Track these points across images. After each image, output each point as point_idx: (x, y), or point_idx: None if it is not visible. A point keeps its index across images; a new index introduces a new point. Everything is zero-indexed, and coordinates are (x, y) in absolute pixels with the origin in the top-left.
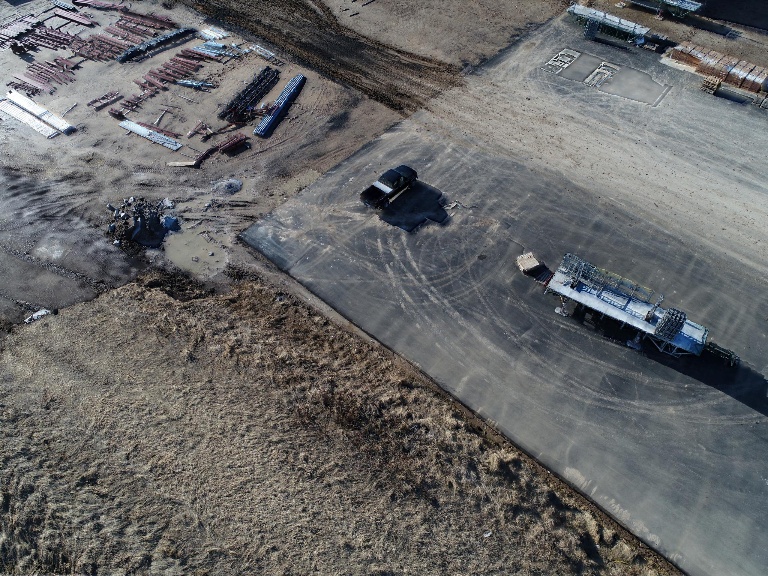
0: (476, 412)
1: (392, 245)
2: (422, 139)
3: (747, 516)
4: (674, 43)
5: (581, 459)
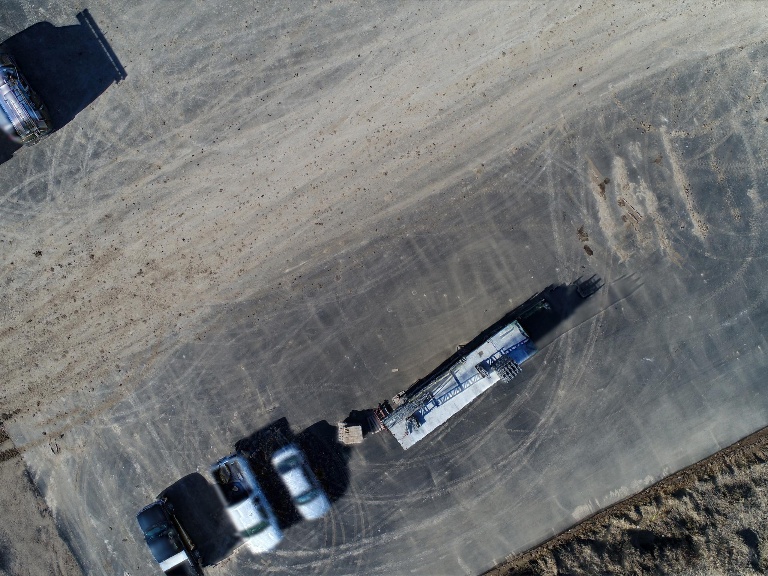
0: (496, 566)
1: (263, 567)
2: (78, 453)
3: (662, 396)
4: None
5: (570, 498)
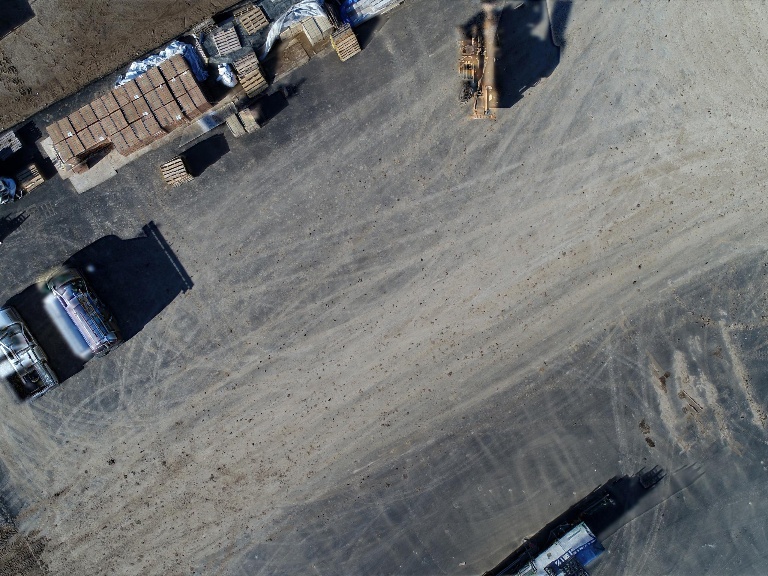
0: None
1: None
2: None
3: None
4: (30, 126)
5: None
